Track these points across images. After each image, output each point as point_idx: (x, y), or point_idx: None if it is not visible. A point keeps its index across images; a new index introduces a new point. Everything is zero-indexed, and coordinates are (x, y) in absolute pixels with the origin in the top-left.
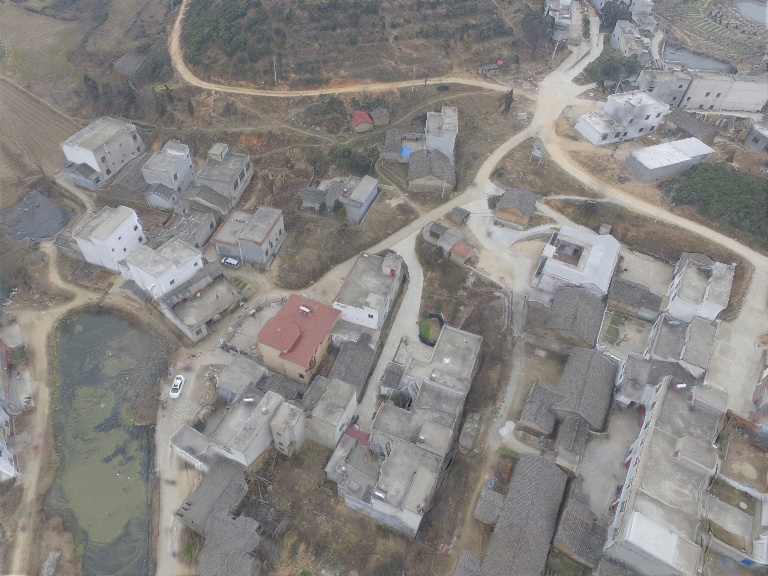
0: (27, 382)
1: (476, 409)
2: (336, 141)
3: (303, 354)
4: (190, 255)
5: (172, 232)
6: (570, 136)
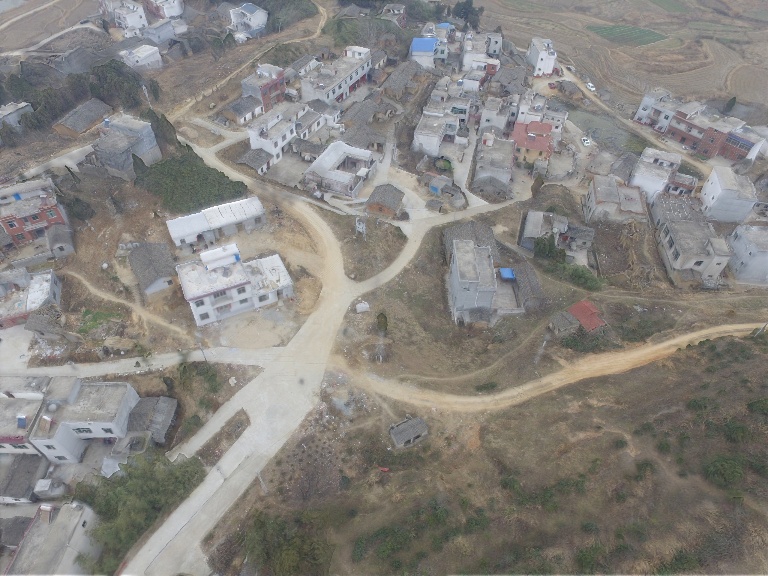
0: (676, 148)
1: (414, 127)
2: (602, 296)
3: (520, 124)
4: (642, 172)
5: (681, 202)
6: (308, 275)
